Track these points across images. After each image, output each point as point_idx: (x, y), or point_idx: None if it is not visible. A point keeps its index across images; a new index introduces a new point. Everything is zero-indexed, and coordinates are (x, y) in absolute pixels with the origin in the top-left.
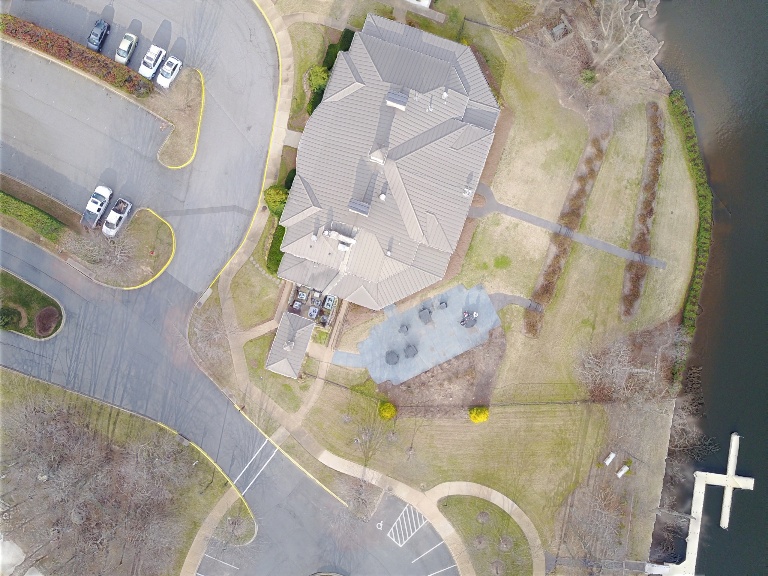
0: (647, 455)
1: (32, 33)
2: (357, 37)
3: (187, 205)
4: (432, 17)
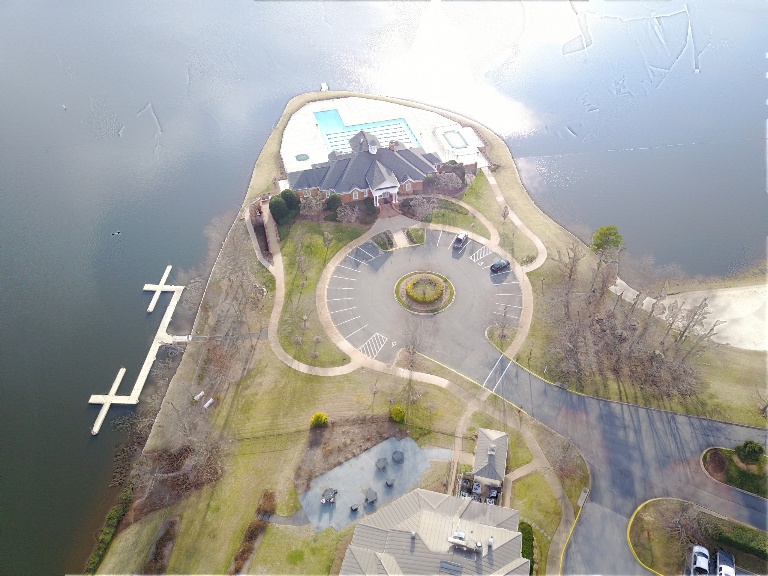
0: None
1: None
2: None
3: None
4: None
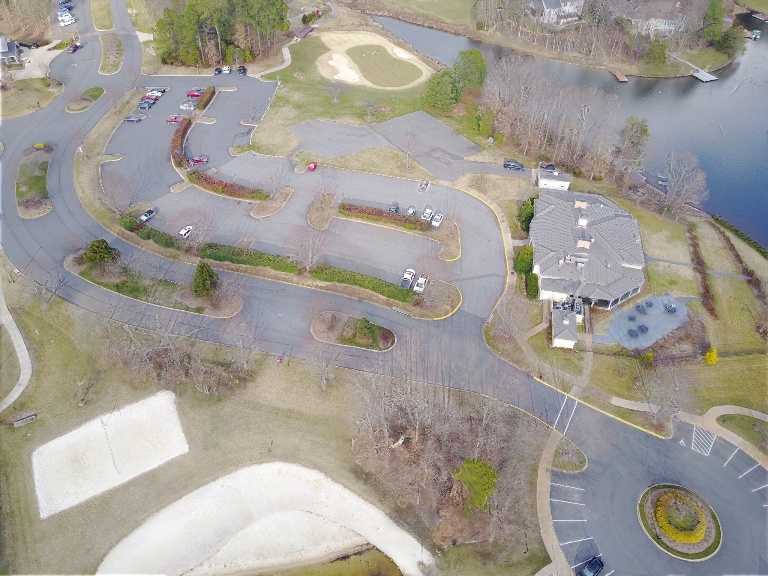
0: None
1: (359, 208)
2: (542, 193)
3: (463, 276)
4: None
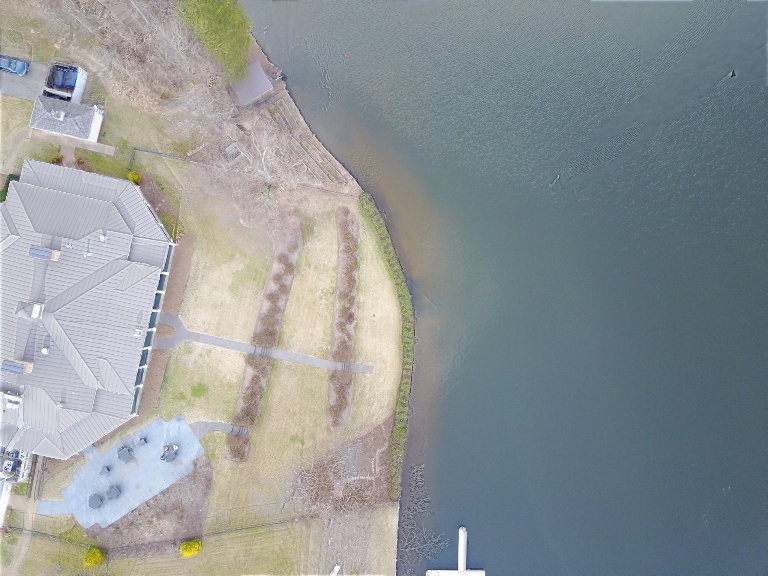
0: (376, 561)
1: None
2: (11, 187)
3: None
4: (101, 151)
